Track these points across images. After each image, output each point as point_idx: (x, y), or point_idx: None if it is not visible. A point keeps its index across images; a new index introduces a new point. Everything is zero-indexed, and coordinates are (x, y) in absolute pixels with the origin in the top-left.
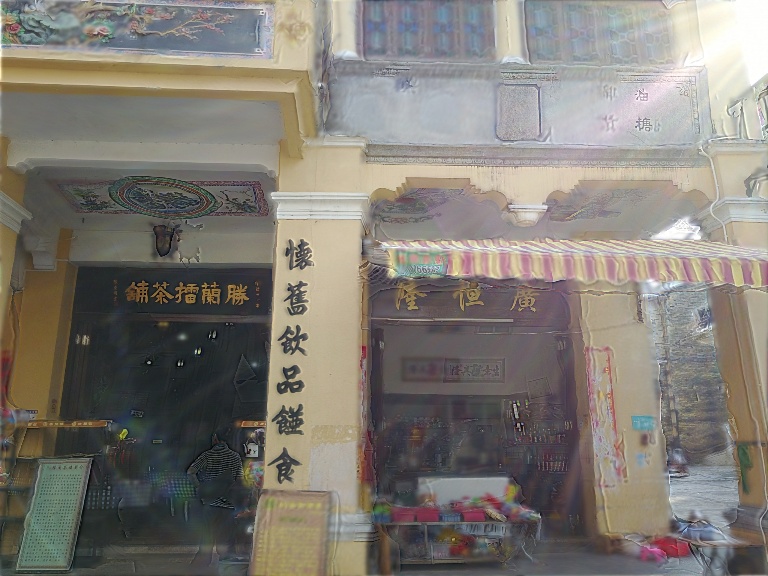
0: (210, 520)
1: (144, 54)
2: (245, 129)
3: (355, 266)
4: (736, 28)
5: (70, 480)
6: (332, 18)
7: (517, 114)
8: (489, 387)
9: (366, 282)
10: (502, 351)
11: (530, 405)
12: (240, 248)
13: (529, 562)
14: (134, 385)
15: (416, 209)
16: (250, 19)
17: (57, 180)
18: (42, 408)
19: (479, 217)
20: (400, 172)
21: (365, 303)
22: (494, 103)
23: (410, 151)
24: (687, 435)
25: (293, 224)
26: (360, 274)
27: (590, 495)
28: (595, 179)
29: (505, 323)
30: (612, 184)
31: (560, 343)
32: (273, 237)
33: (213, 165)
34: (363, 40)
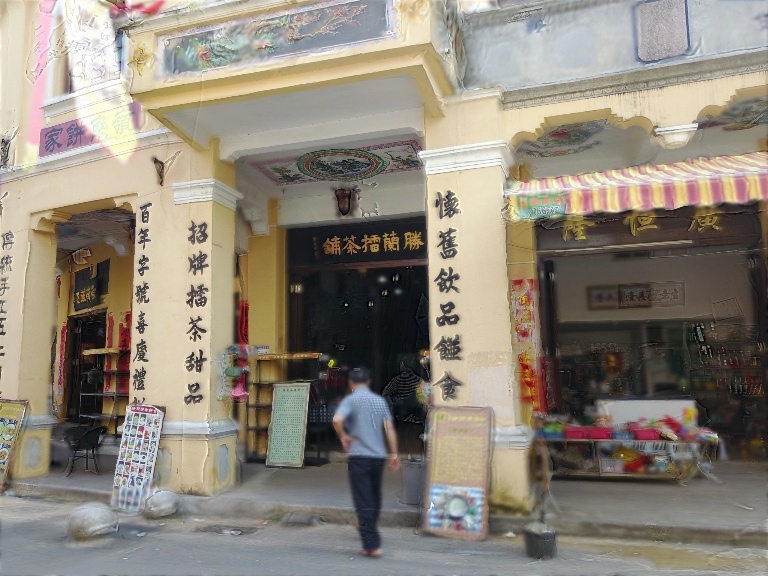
0: (404, 433)
1: (300, 56)
2: (392, 99)
3: (498, 209)
4: None
5: (296, 400)
6: None
7: (661, 31)
8: (668, 311)
9: (509, 223)
10: (681, 274)
11: (717, 327)
12: (410, 199)
13: (705, 480)
14: (336, 324)
15: (572, 141)
16: (380, 5)
17: (257, 164)
18: (271, 345)
19: (636, 141)
20: (538, 113)
21: (529, 238)
22: (634, 24)
23: (547, 91)
24: None
25: (440, 178)
26: (502, 216)
27: None
28: (756, 85)
29: (682, 245)
30: None
31: (750, 261)
32: None
33: (371, 134)
34: None
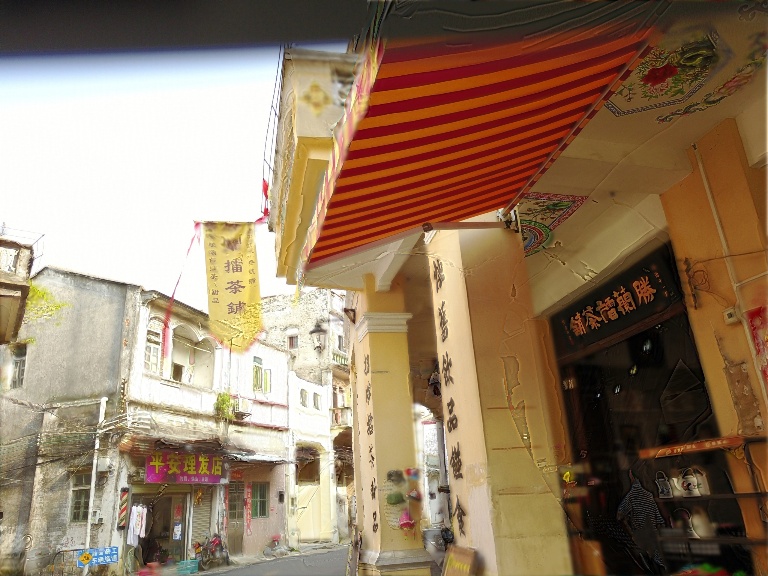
0: None
1: None
2: None
3: None
4: None
5: None
6: (333, 54)
7: None
8: None
9: (465, 274)
10: None
11: None
12: (601, 243)
13: None
14: (586, 423)
15: None
16: None
17: (415, 280)
18: (547, 456)
19: None
20: None
21: (754, 233)
22: None
23: None
24: None
25: None
26: None
27: None
28: None
29: None
30: None
31: None
32: (611, 215)
33: None
34: None
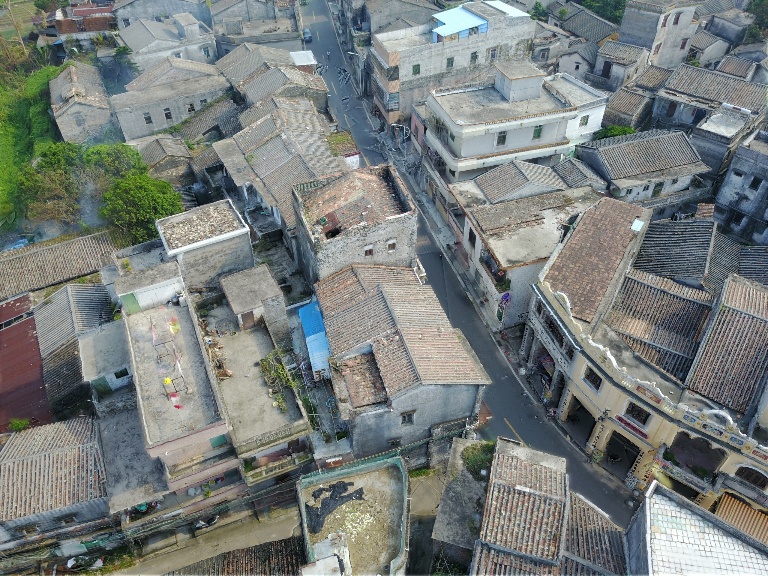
0: None
1: None
2: None
3: (715, 498)
4: None
5: None
6: None
7: (760, 499)
8: None
9: None
10: None
11: None
12: None
13: None
14: None
15: None
16: None
17: None
18: None
19: None
20: (731, 491)
21: None
22: None
23: None
24: None
25: None
26: None
27: None
28: None
29: None
30: None
31: None
32: None
33: None
34: (736, 472)
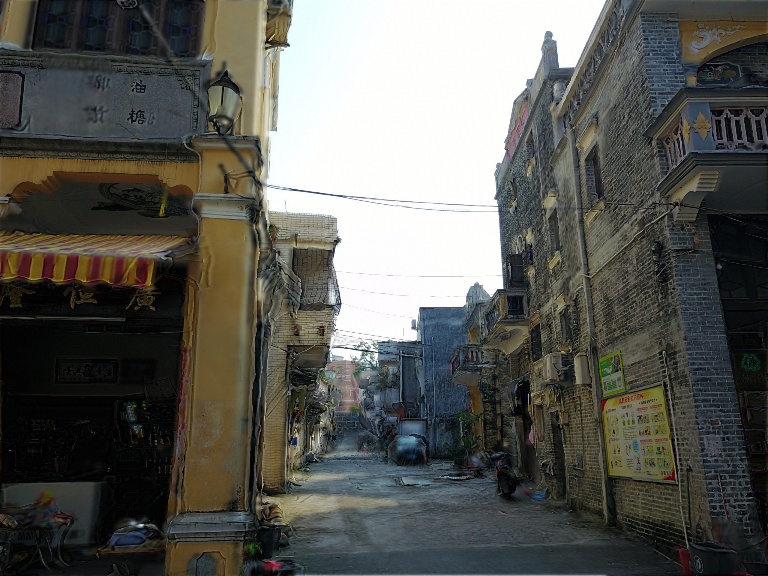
0: None
1: None
2: None
3: None
4: (253, 24)
5: None
6: None
7: None
8: (101, 388)
9: None
10: (116, 351)
11: (149, 407)
12: None
13: (43, 570)
14: None
15: None
16: None
17: None
18: None
19: None
20: None
21: None
22: None
23: None
24: (511, 438)
25: None
26: None
27: (166, 499)
28: (73, 171)
29: (116, 322)
30: (91, 177)
31: None
32: None
33: None
34: None
